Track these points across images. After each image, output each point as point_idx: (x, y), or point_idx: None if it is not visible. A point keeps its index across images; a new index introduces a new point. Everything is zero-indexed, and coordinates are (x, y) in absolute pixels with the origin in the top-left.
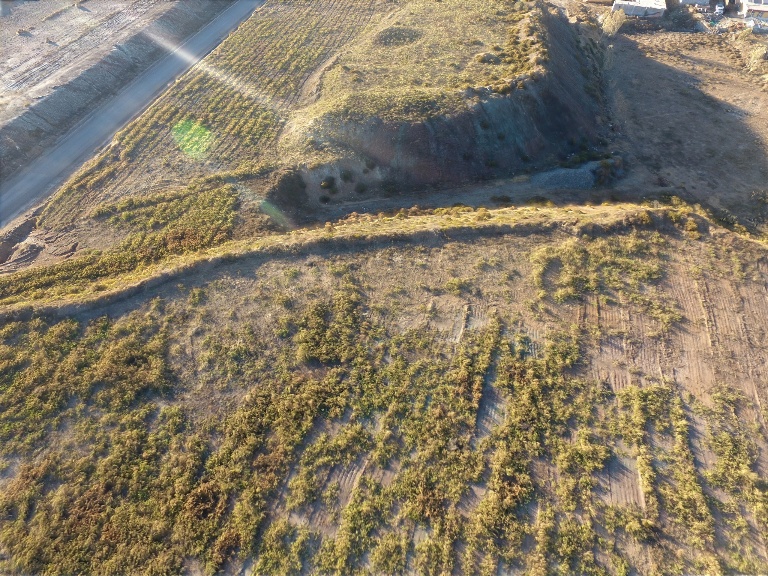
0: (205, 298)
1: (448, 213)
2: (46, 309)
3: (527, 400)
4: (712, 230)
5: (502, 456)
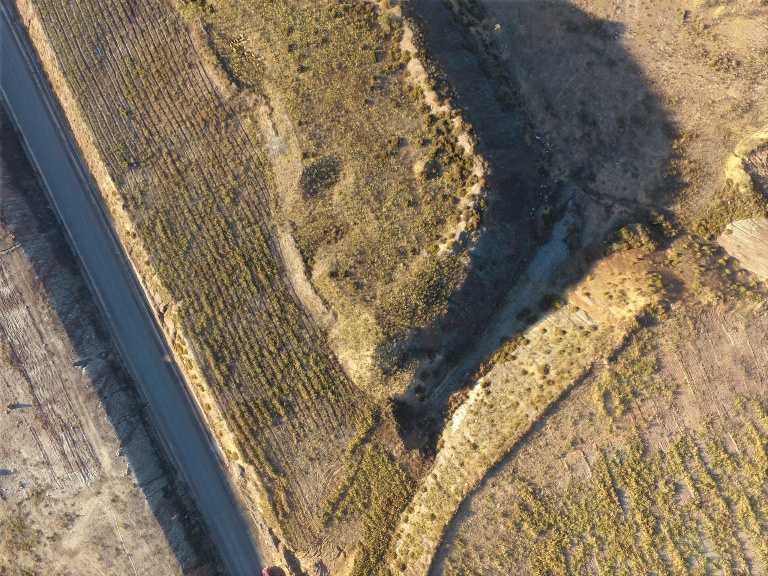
0: (465, 541)
1: (507, 360)
2: None
3: (636, 486)
4: (673, 307)
5: (640, 517)
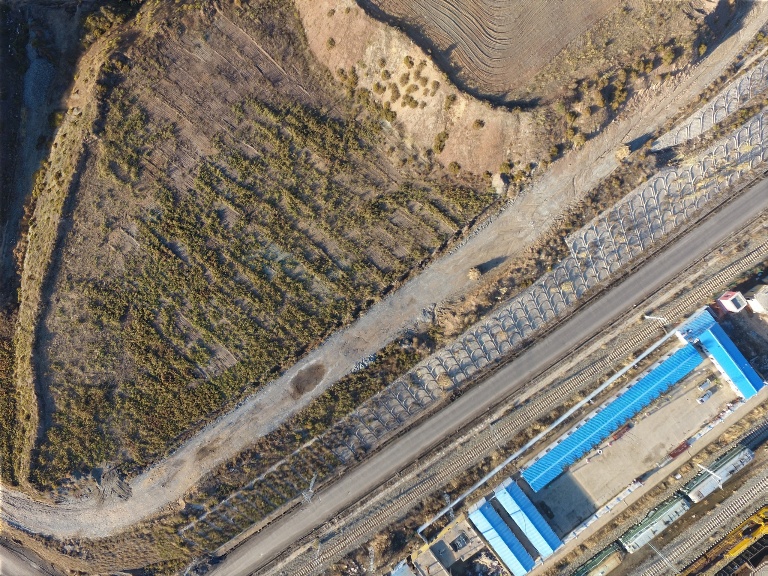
0: (60, 362)
1: (41, 190)
2: (36, 443)
3: (181, 232)
4: (127, 55)
5: (199, 257)
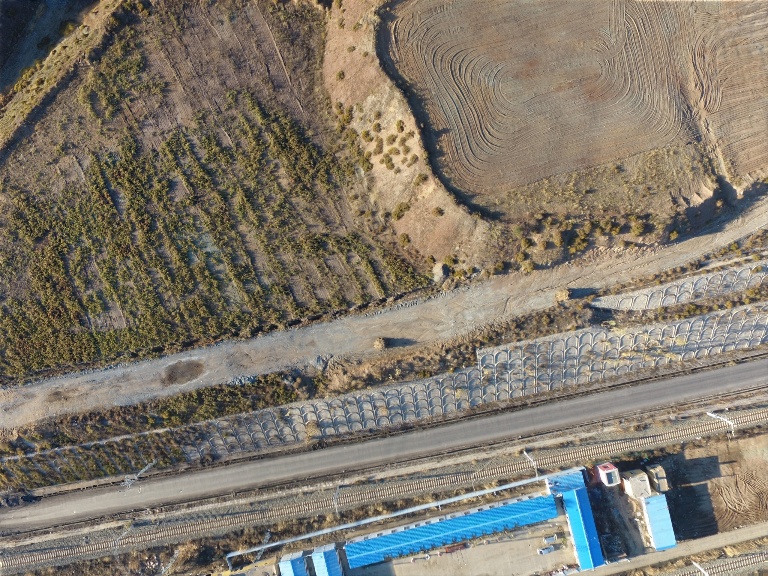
0: None
1: (23, 87)
2: None
3: (128, 185)
4: (151, 2)
5: (134, 215)
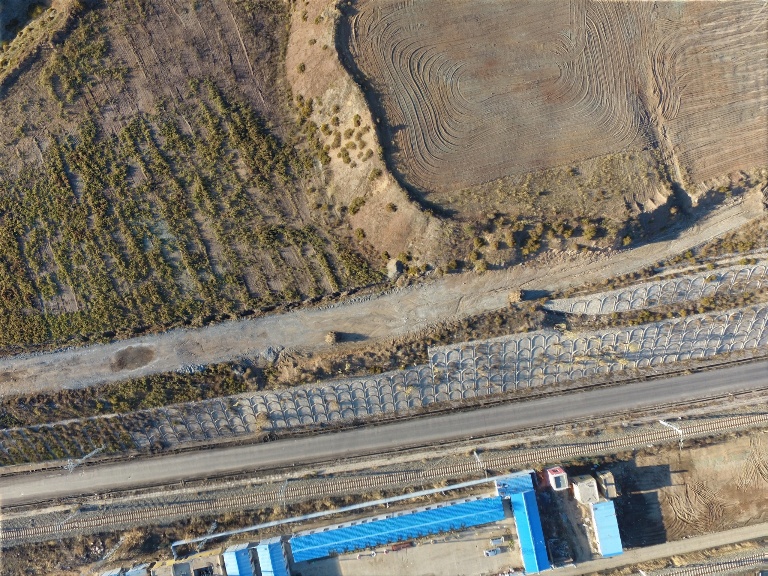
0: None
1: None
2: None
3: (86, 168)
4: None
5: (90, 199)
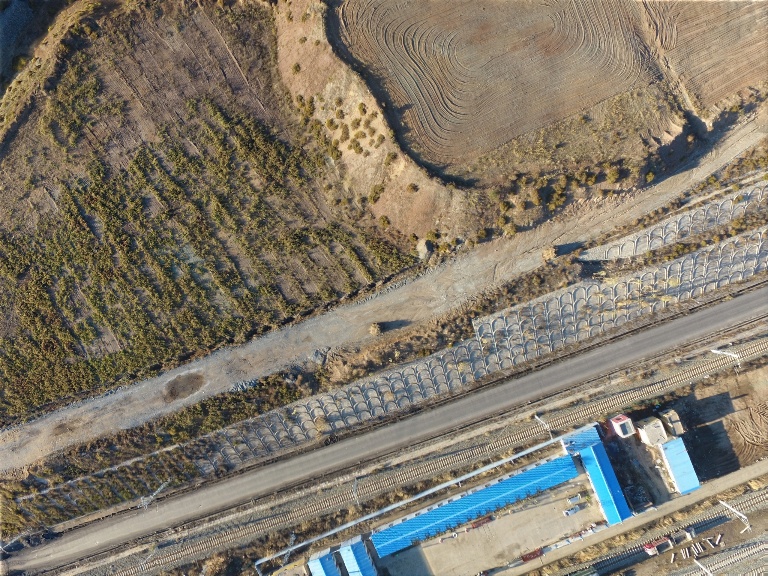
0: None
1: None
2: None
3: (101, 208)
4: (98, 24)
5: (112, 237)
